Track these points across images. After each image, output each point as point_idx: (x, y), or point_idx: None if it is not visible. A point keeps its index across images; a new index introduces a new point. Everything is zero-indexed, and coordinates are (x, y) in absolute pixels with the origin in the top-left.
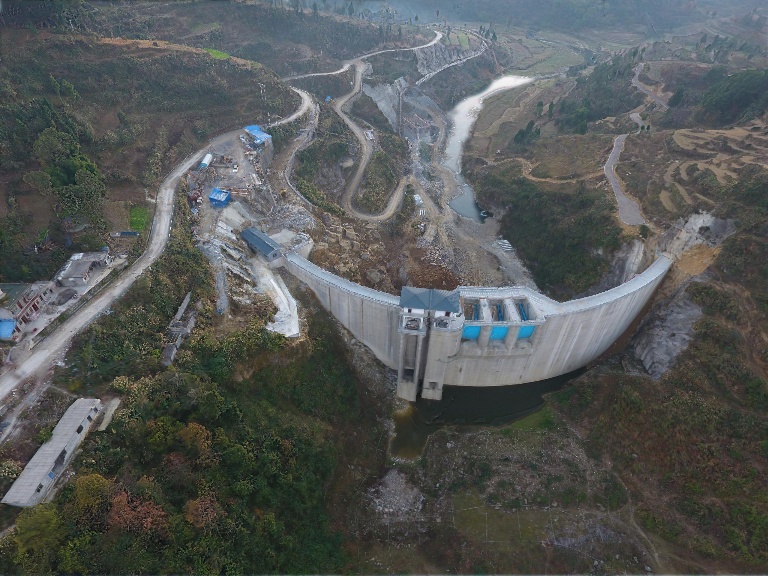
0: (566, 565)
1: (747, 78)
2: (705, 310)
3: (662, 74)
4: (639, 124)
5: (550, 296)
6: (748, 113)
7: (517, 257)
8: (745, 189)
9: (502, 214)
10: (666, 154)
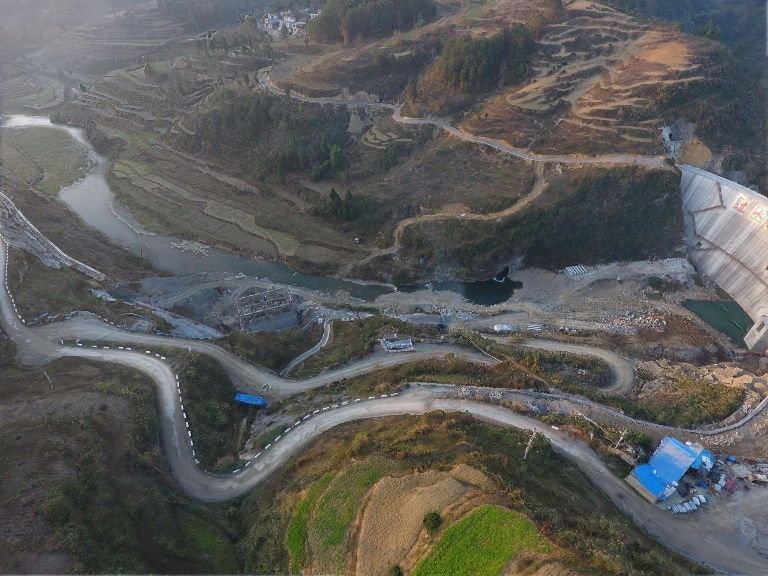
0: None
1: (484, 45)
2: (740, 168)
3: (330, 81)
4: (431, 123)
5: (664, 253)
6: (528, 66)
7: (594, 266)
8: (667, 100)
9: (520, 261)
10: (541, 121)
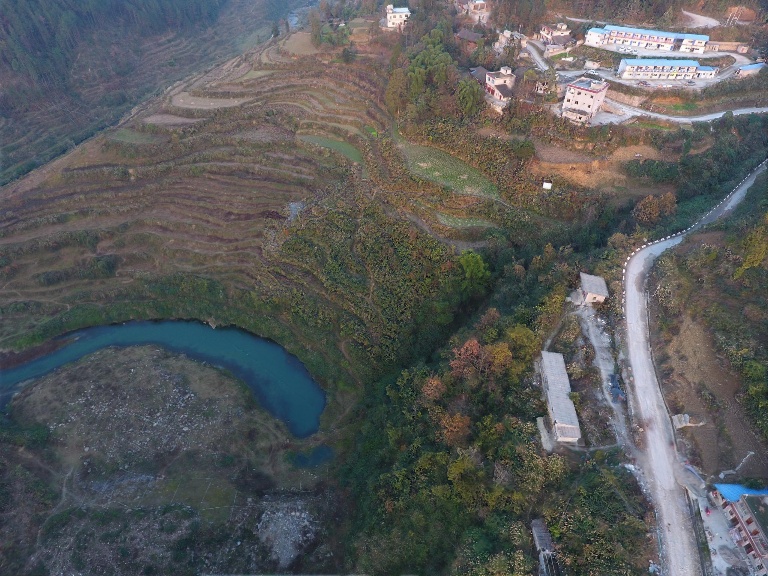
0: (154, 465)
1: None
2: None
3: None
4: None
5: None
6: None
7: None
8: None
9: None
10: None
